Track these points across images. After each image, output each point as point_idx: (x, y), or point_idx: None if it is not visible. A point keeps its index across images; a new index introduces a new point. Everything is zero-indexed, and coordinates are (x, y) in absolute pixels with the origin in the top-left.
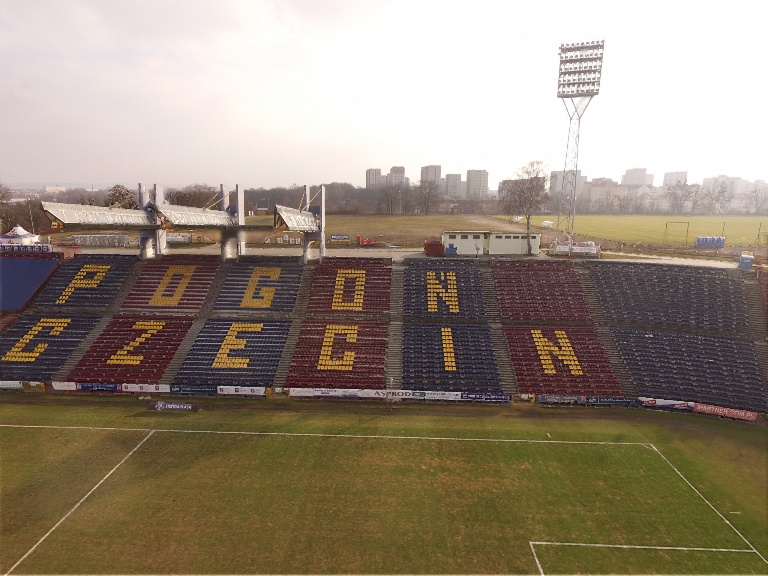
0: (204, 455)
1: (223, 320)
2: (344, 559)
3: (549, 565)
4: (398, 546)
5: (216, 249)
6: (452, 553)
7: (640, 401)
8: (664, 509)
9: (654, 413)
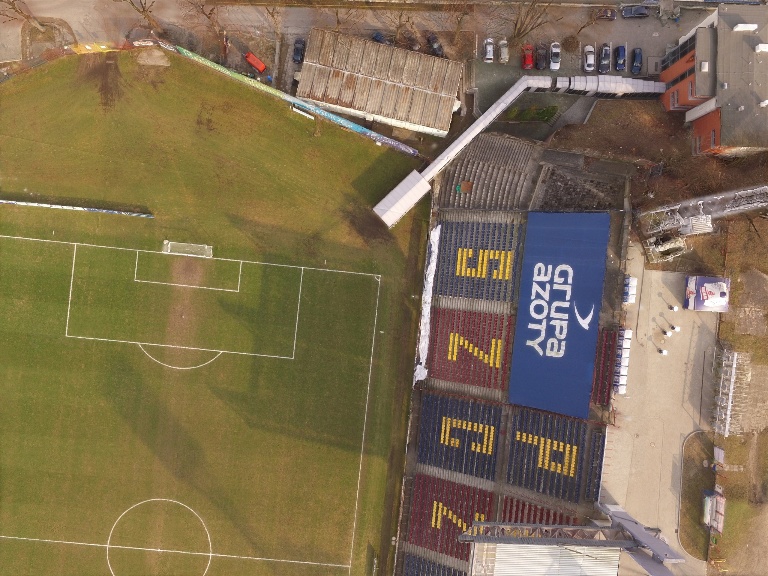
0: None
1: None
2: None
3: None
4: None
5: None
6: None
7: None
8: None
9: None
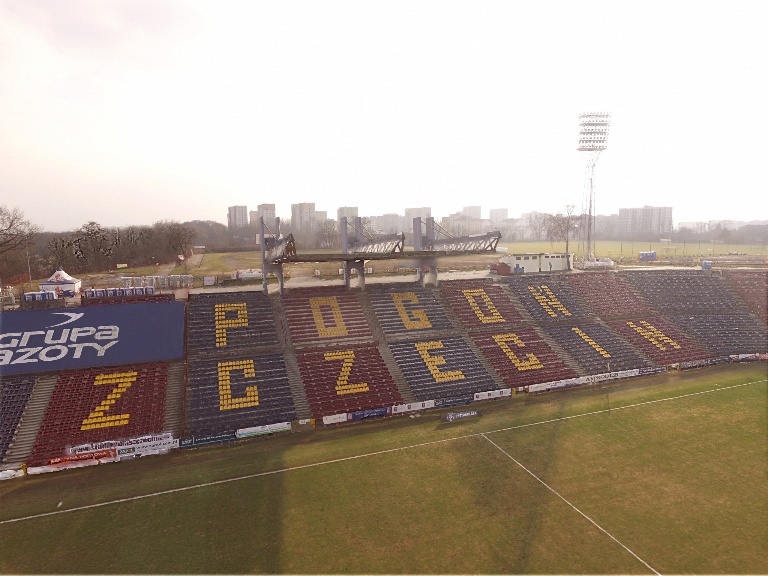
0: (557, 439)
1: (403, 342)
2: (761, 466)
3: None
4: None
5: (305, 282)
6: None
7: (731, 358)
8: None
9: (740, 364)
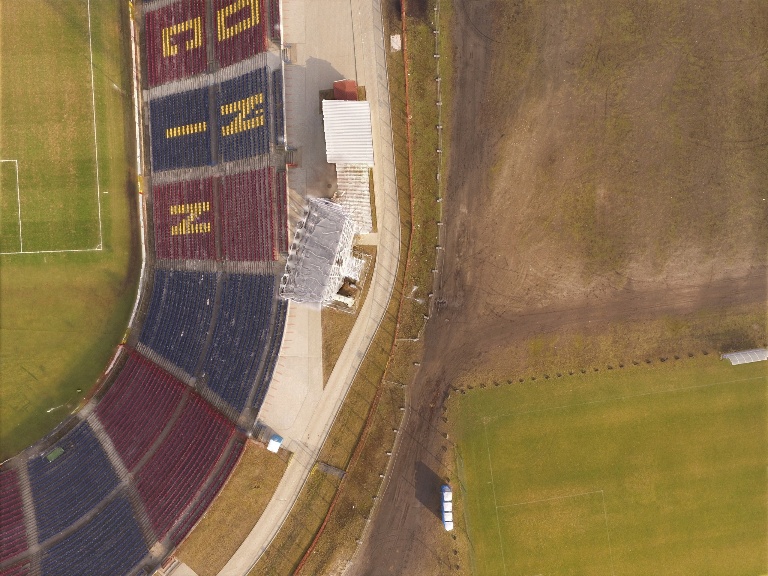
0: None
1: None
2: None
3: (5, 165)
4: (8, 104)
5: None
6: (7, 126)
7: None
8: (44, 228)
9: None
